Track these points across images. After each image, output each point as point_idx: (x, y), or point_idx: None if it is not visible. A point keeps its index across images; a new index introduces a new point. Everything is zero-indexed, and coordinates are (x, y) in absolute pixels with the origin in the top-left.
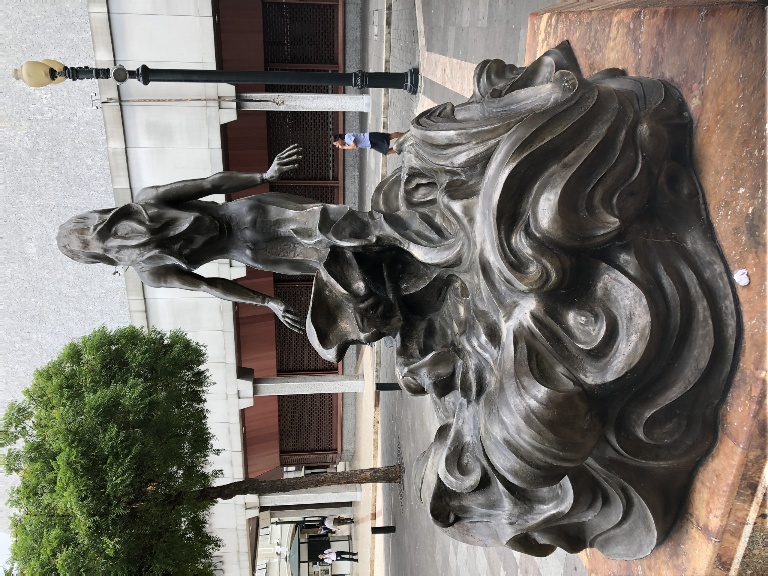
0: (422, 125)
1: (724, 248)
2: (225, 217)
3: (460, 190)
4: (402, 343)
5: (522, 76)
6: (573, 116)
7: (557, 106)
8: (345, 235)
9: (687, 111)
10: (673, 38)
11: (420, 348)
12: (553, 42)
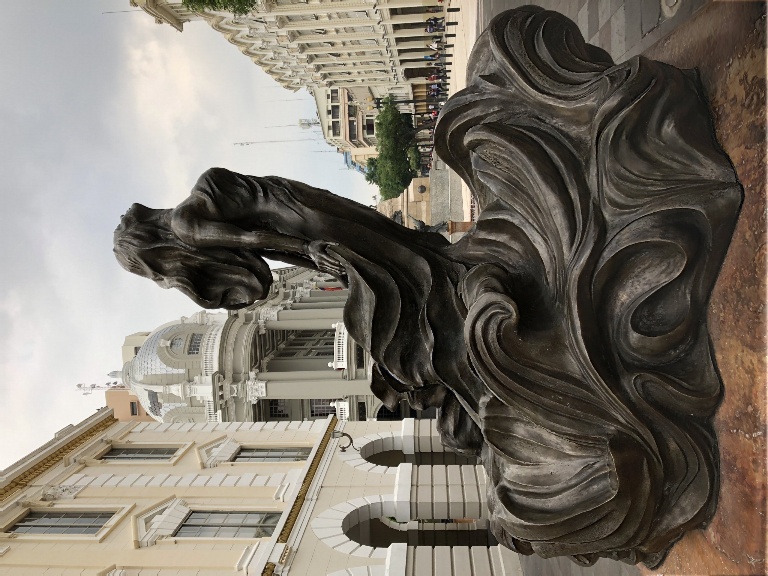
0: (476, 344)
1: (668, 558)
2: (269, 226)
3: (499, 419)
4: (443, 414)
5: (639, 244)
6: (585, 536)
7: (579, 519)
8: (396, 358)
9: (707, 524)
10: (740, 505)
11: (455, 425)
12: (743, 134)
